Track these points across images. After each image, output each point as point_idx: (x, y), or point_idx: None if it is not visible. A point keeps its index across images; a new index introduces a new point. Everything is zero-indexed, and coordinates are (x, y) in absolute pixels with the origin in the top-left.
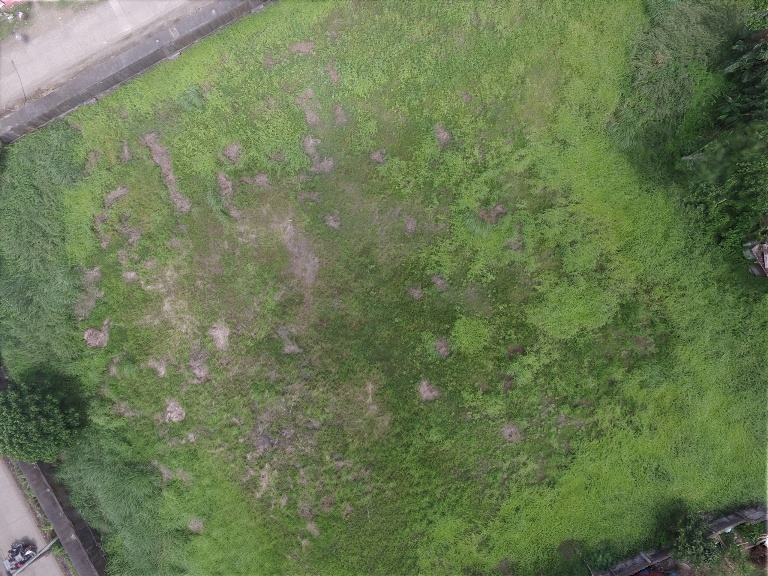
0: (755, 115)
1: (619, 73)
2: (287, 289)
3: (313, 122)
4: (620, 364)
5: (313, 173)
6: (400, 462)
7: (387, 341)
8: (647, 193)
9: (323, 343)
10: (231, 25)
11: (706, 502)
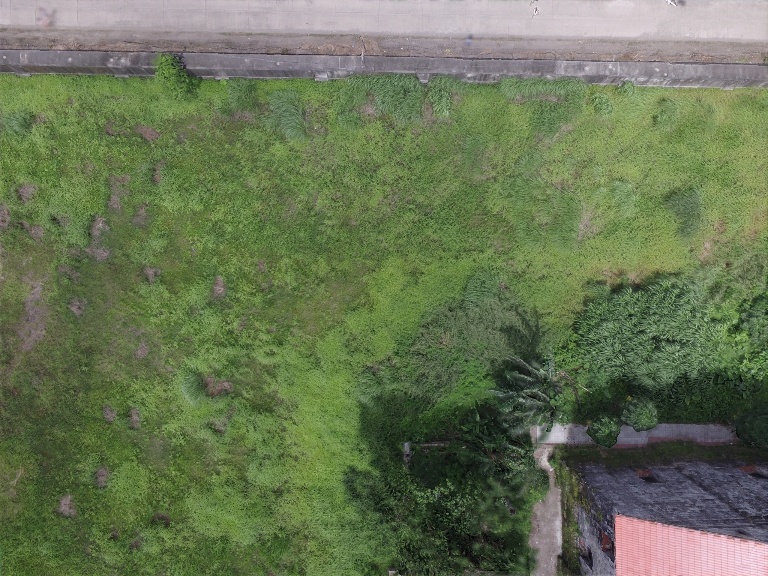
0: (484, 449)
1: (406, 330)
2: (2, 343)
3: (114, 208)
4: None
5: (85, 254)
6: (6, 552)
7: (59, 441)
8: (360, 453)
9: (3, 409)
10: (89, 77)
11: None
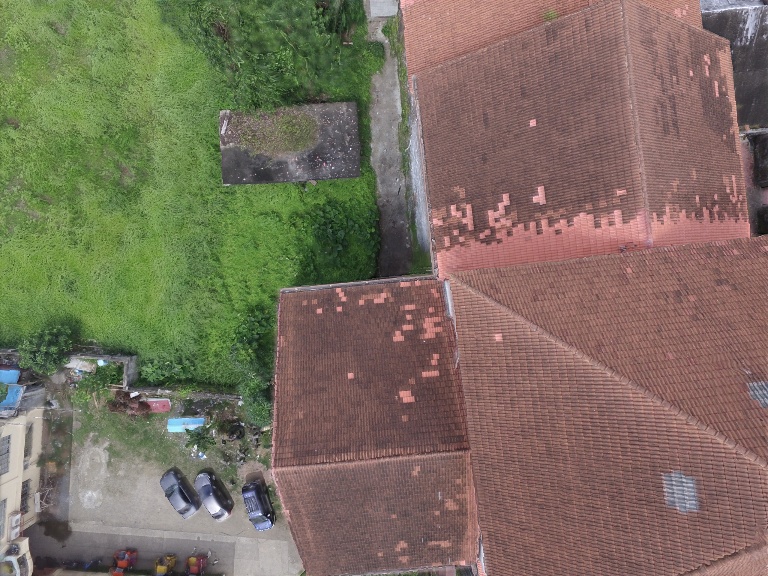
0: None
1: None
2: None
3: None
4: (95, 180)
5: None
6: None
7: None
8: None
9: None
10: None
11: (99, 333)
